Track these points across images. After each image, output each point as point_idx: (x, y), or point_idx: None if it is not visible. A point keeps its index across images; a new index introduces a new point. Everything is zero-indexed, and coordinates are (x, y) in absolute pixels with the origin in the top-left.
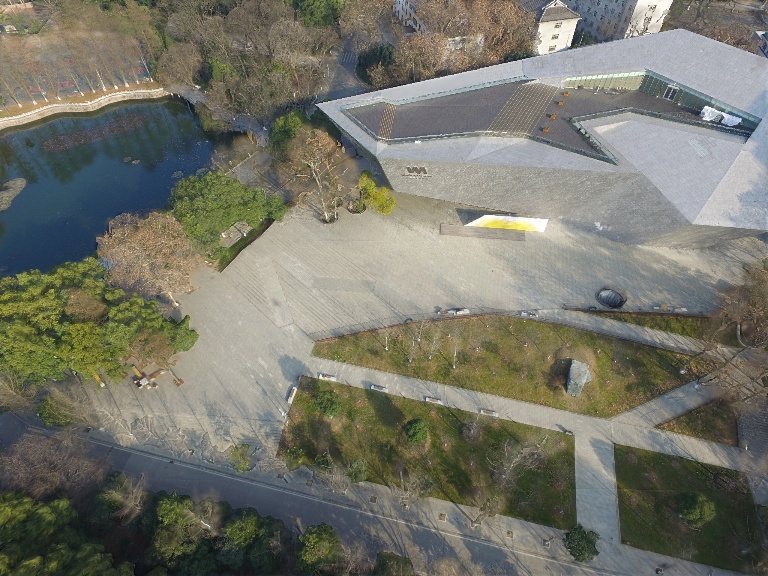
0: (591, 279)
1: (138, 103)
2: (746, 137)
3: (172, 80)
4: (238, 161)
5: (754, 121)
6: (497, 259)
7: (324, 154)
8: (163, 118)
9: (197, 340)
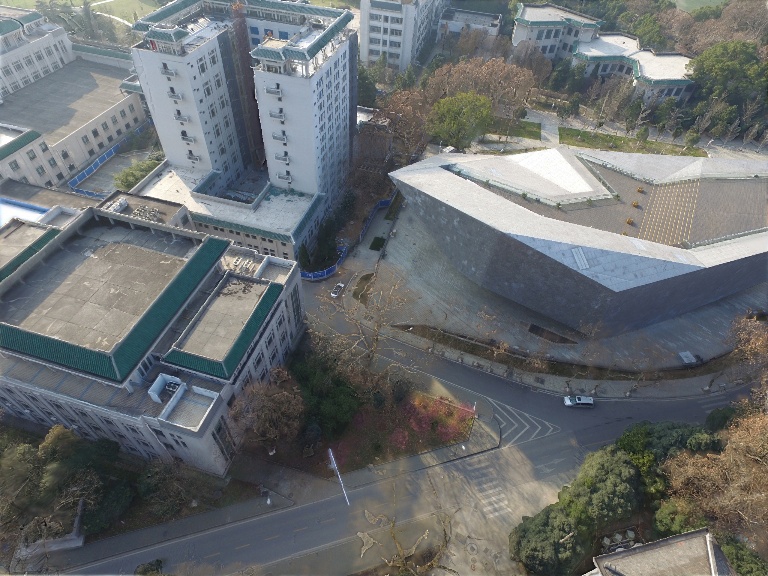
0: None
1: None
2: (451, 169)
3: None
4: None
5: None
6: None
7: None
8: None
9: None
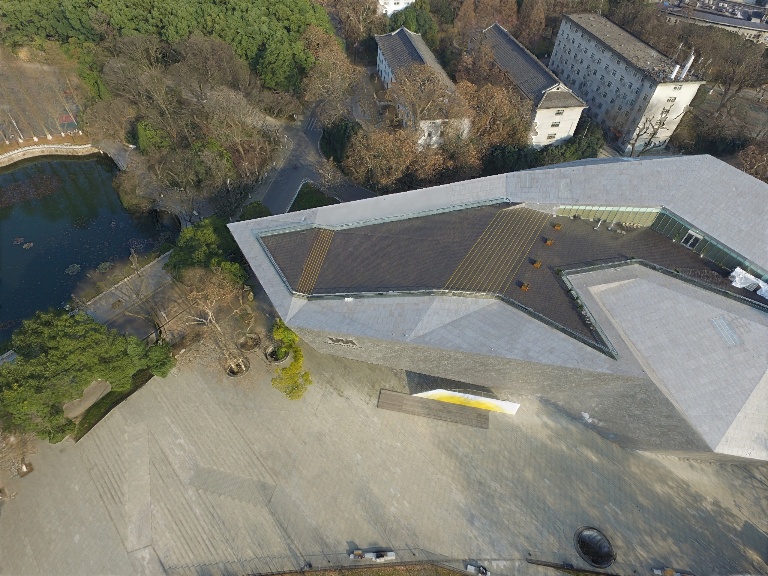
0: (570, 506)
1: (61, 159)
2: None
3: (105, 134)
4: (149, 260)
5: None
6: (447, 458)
7: (236, 286)
8: (96, 173)
9: (7, 567)
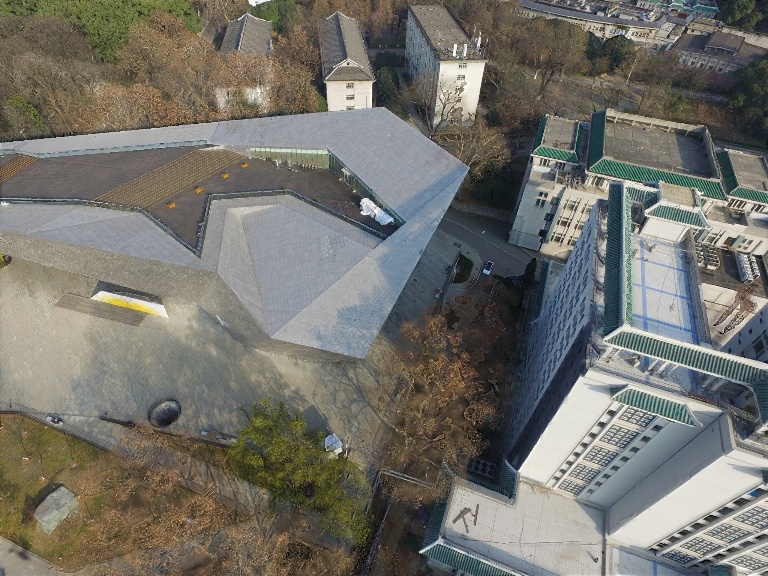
0: (166, 384)
1: None
2: None
3: None
4: None
5: (402, 223)
6: (87, 344)
7: None
8: None
9: None
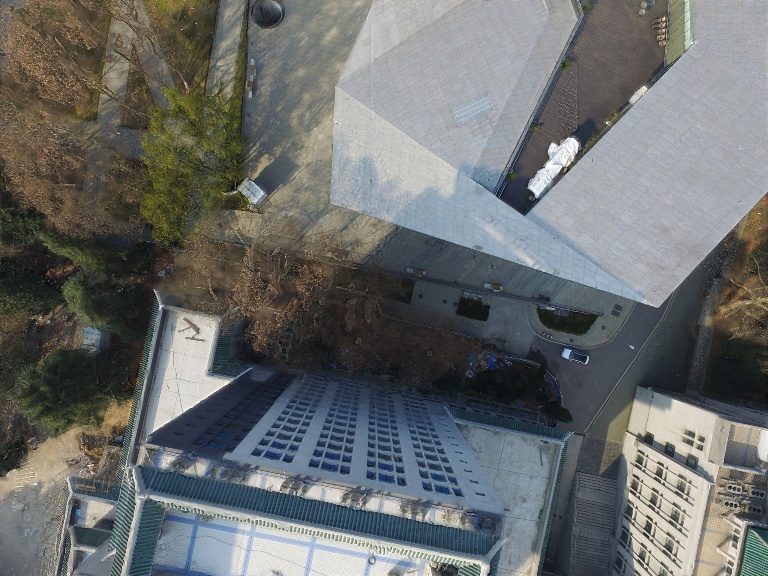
0: None
1: None
2: None
3: None
4: None
5: None
6: None
7: None
8: None
9: None
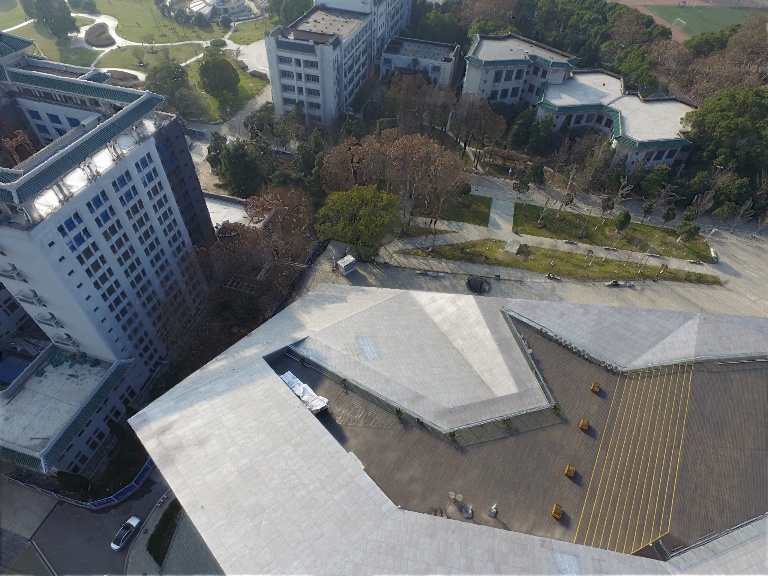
0: None
1: None
2: None
3: None
4: None
5: None
6: None
7: None
8: None
9: None
